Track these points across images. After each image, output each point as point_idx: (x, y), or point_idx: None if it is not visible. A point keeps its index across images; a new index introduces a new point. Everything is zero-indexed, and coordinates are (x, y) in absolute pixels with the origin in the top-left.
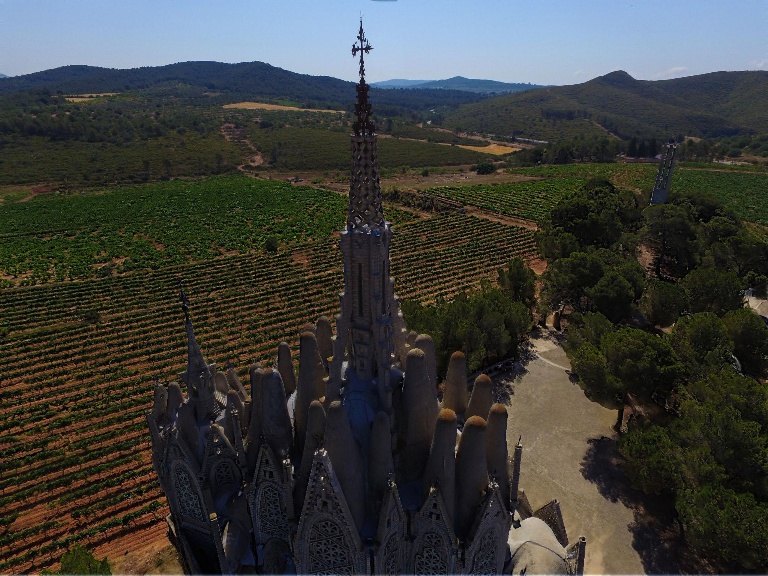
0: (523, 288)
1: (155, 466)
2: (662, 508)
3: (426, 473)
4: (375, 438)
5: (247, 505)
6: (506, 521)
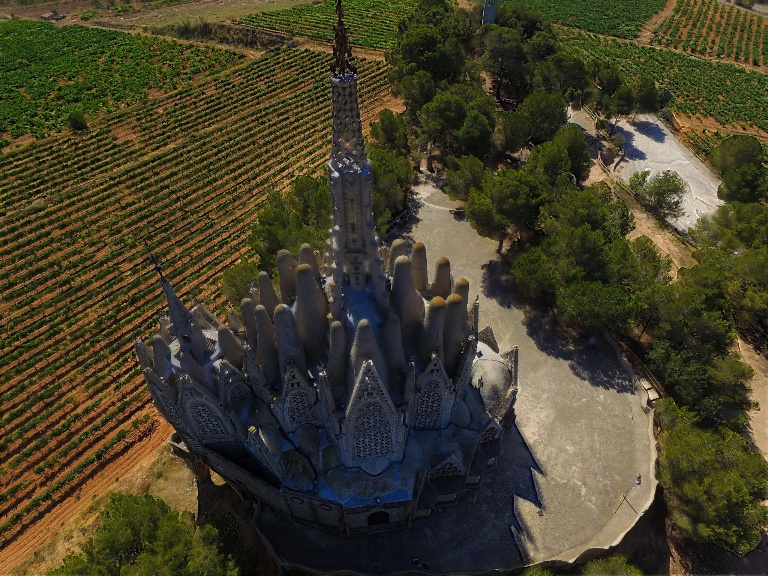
0: (397, 139)
1: (159, 409)
2: (540, 302)
3: (423, 345)
4: (391, 335)
5: (269, 410)
6: (473, 355)
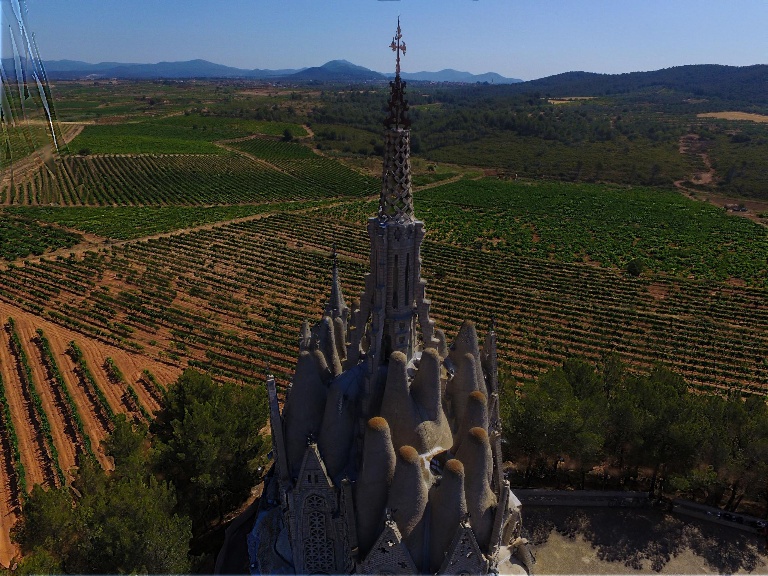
0: None
1: None
2: None
3: None
4: None
5: None
6: None
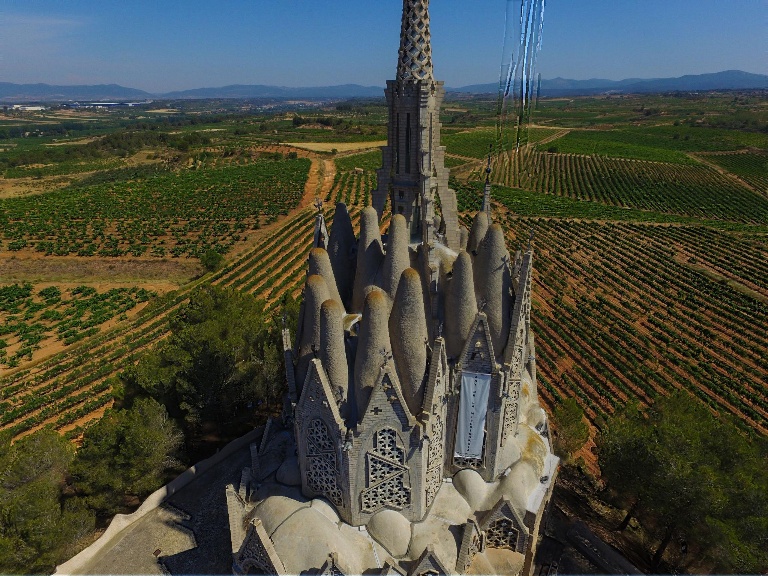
0: None
1: None
2: None
3: None
4: None
5: None
6: None
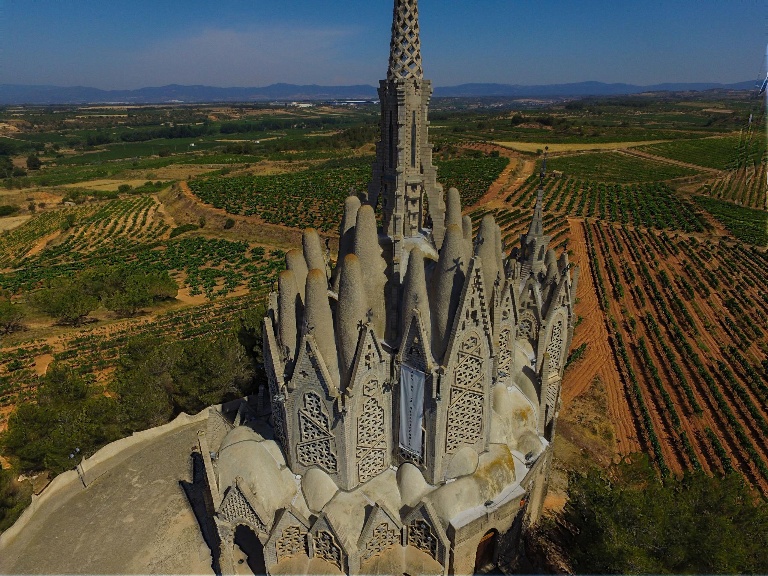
0: None
1: None
2: None
3: None
4: None
5: None
6: None
